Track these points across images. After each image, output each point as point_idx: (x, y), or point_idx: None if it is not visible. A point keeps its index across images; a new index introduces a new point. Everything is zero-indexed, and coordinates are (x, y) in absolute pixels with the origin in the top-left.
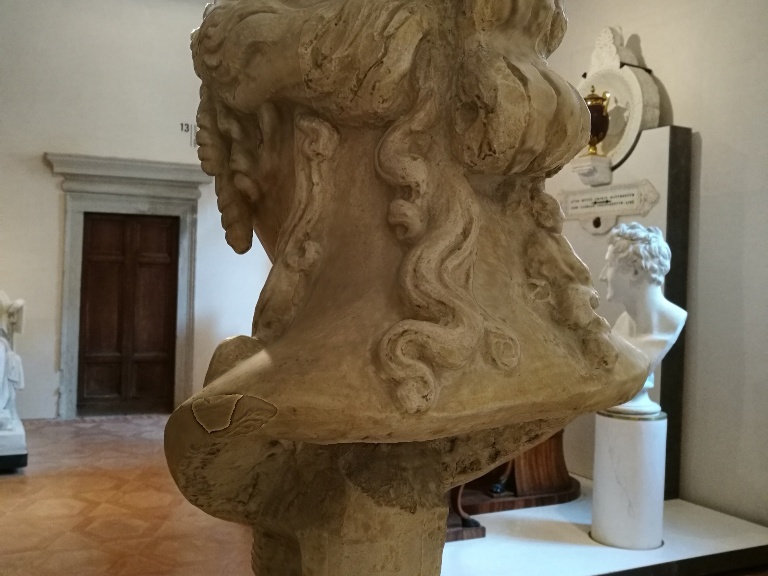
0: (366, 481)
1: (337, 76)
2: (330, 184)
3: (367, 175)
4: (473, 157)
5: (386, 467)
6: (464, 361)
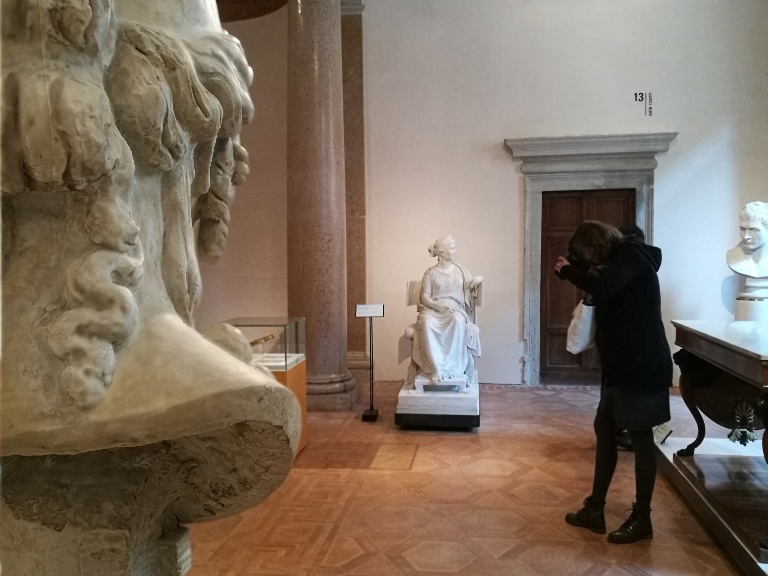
0: (14, 493)
1: None
2: None
3: None
4: None
5: (41, 482)
6: None
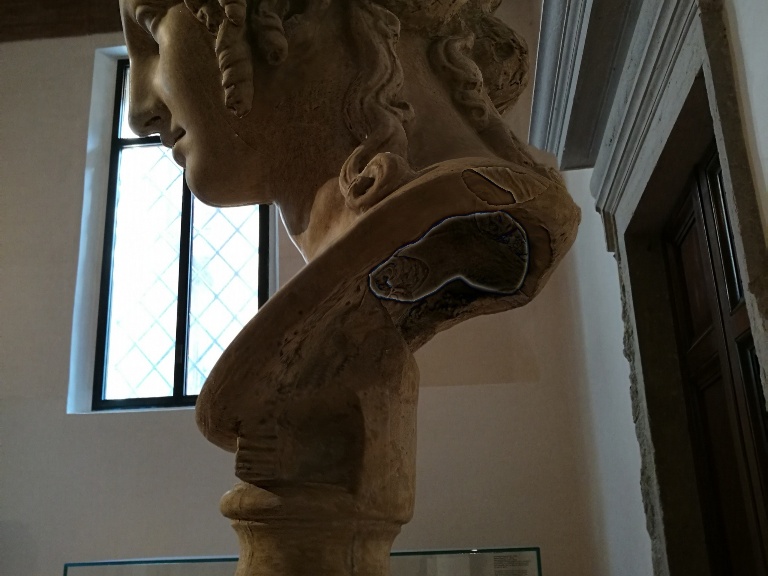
0: None
1: None
2: None
3: (426, 69)
4: (506, 81)
5: None
6: None
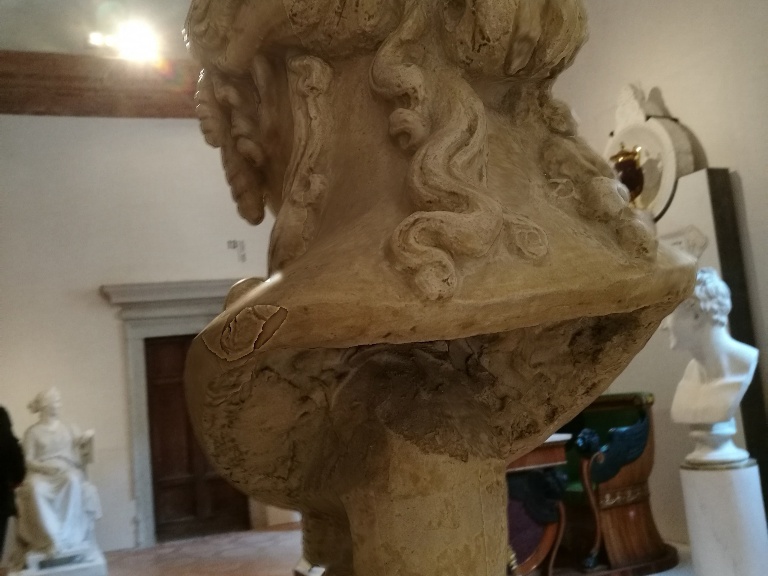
0: (408, 429)
1: (320, 4)
2: (329, 117)
3: (364, 100)
4: (468, 51)
5: (429, 415)
6: (485, 245)
